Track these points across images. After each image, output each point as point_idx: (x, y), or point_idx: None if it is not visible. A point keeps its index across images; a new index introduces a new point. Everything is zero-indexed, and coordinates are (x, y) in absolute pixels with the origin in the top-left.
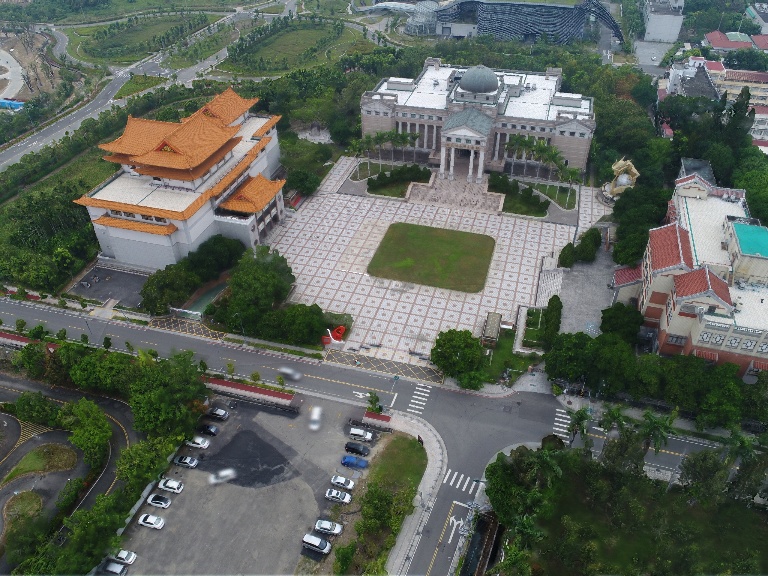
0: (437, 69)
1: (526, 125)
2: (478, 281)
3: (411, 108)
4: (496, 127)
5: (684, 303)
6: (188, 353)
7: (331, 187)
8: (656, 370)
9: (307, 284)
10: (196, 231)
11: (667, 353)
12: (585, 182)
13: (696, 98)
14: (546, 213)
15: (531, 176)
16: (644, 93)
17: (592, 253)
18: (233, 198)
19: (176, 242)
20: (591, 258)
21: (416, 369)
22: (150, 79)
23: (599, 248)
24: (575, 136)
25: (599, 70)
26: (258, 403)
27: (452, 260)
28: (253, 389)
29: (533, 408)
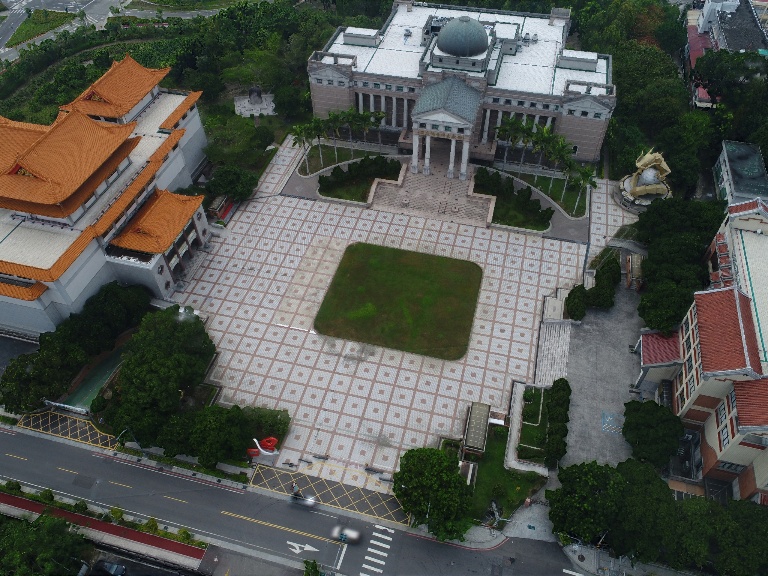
0: (410, 10)
1: (524, 101)
2: (459, 340)
3: (374, 76)
4: (485, 102)
5: (750, 434)
6: (42, 521)
7: (273, 185)
8: (706, 531)
9: (234, 350)
10: (77, 285)
11: (714, 478)
12: (597, 172)
13: (745, 55)
14: (548, 224)
15: (529, 163)
16: (672, 35)
17: (610, 300)
18: (129, 231)
19: (51, 302)
20: (608, 306)
21: (374, 498)
22: (54, 16)
23: (617, 284)
24: (588, 116)
25: (616, 3)
26: (156, 563)
27: (426, 305)
28: (150, 539)
29: (532, 569)
